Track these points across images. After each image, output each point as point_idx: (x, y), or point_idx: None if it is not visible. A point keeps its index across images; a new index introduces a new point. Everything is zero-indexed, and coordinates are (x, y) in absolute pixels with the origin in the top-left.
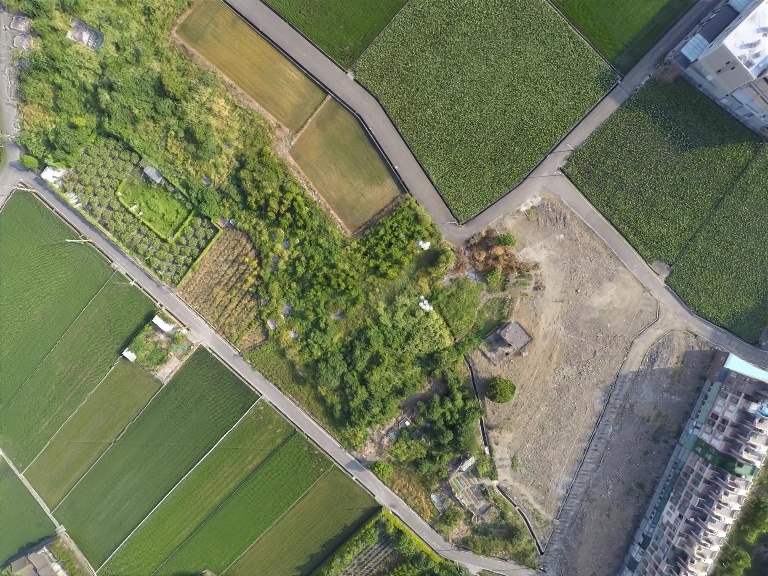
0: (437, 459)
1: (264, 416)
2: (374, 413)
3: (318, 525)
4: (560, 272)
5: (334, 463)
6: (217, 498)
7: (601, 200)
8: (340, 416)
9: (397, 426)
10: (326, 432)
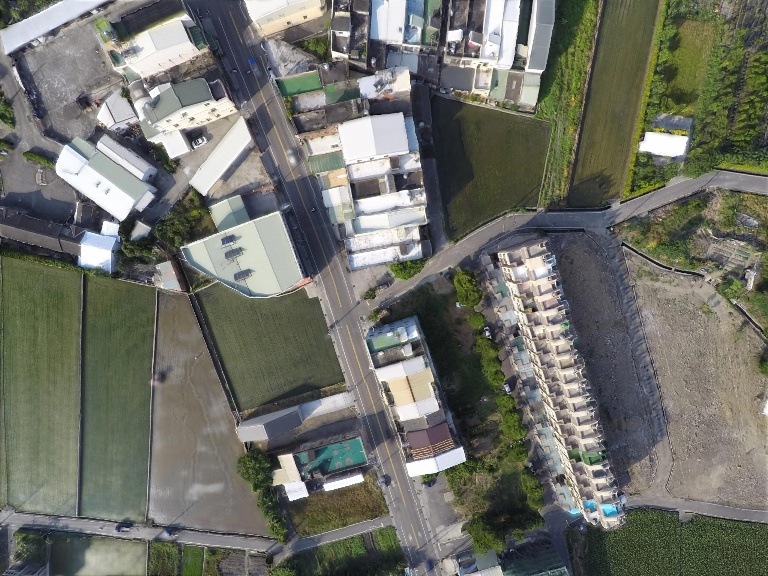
0: None
1: None
2: None
3: None
4: (761, 470)
5: None
6: None
7: (759, 530)
8: None
9: None
10: None
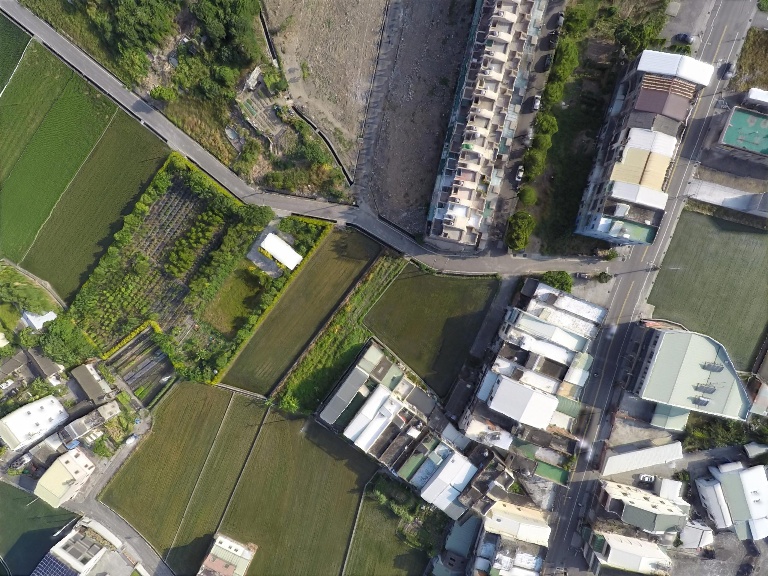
0: (217, 69)
1: (39, 60)
2: (140, 17)
3: (113, 186)
4: None
5: (119, 106)
6: (4, 170)
7: None
8: (113, 40)
9: (176, 47)
10: (107, 71)
